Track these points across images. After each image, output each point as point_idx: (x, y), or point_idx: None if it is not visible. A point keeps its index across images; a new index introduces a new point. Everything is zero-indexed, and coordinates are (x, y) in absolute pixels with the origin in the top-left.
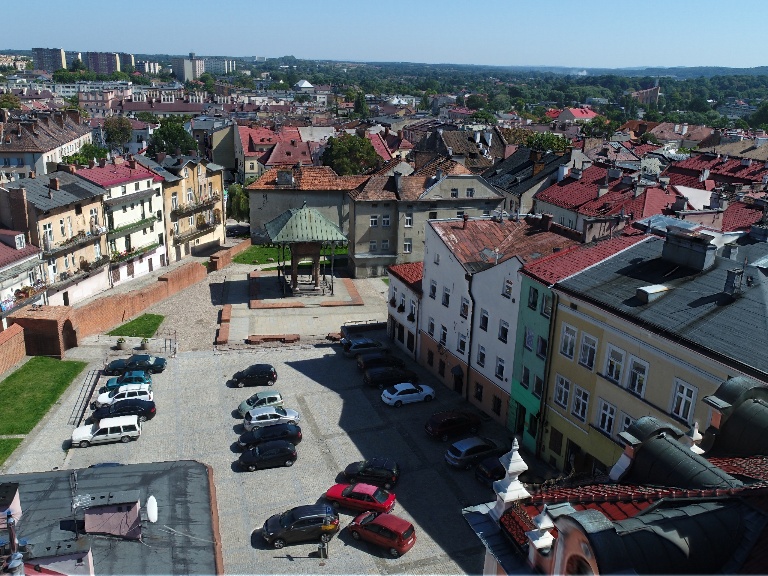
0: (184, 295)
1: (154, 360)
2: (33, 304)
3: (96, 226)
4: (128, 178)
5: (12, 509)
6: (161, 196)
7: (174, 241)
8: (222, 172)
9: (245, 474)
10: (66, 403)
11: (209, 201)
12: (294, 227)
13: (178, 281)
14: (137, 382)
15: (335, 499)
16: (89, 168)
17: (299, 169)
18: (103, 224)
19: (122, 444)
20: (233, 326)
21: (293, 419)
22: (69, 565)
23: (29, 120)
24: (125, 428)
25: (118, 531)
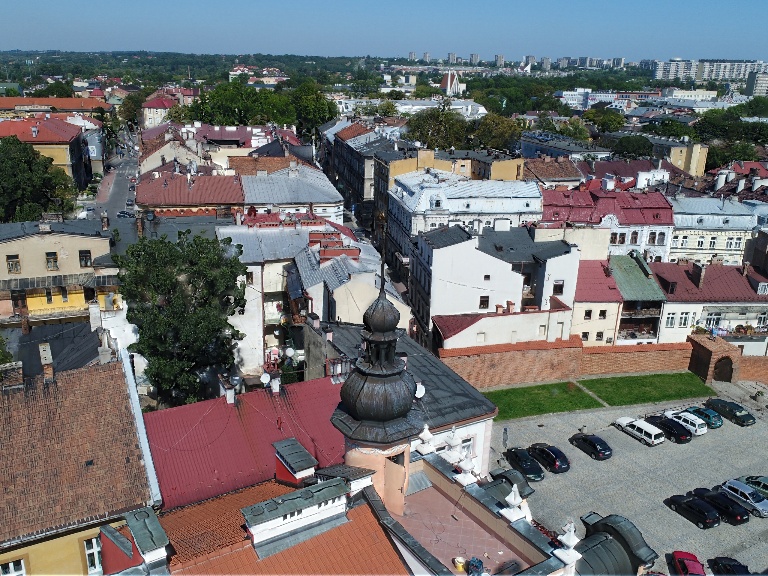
0: None
1: (744, 414)
2: (715, 335)
3: None
4: None
5: None
6: None
7: None
8: None
9: (666, 507)
10: (659, 406)
11: None
12: None
13: None
14: (706, 418)
15: (674, 557)
16: None
17: None
18: None
19: (640, 443)
20: None
21: (760, 509)
22: None
23: None
24: (646, 433)
25: None
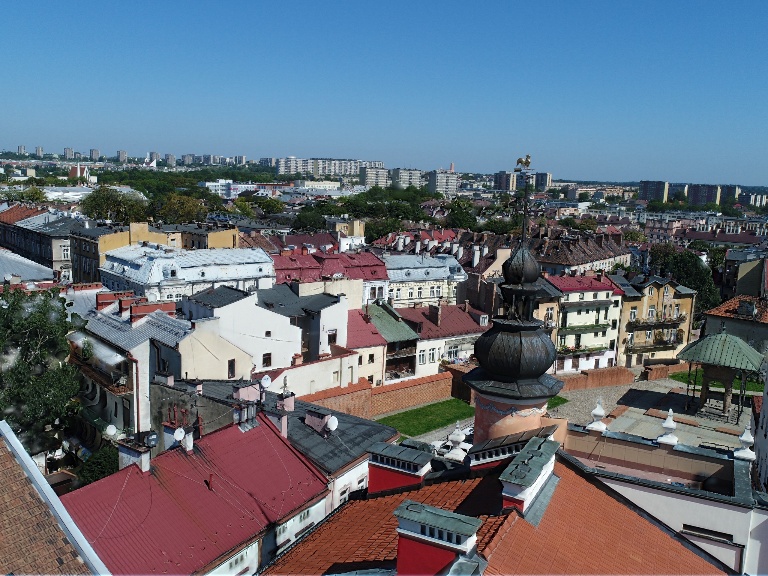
0: (600, 391)
1: None
2: None
3: (550, 321)
4: (588, 288)
5: (285, 402)
6: (619, 307)
7: (626, 349)
8: (694, 296)
9: None
10: (449, 429)
11: (671, 320)
12: (704, 349)
13: (599, 378)
14: None
15: None
16: (561, 276)
17: (765, 302)
18: (557, 321)
19: None
20: (616, 422)
21: None
22: (276, 420)
23: (571, 239)
24: None
25: (317, 429)
